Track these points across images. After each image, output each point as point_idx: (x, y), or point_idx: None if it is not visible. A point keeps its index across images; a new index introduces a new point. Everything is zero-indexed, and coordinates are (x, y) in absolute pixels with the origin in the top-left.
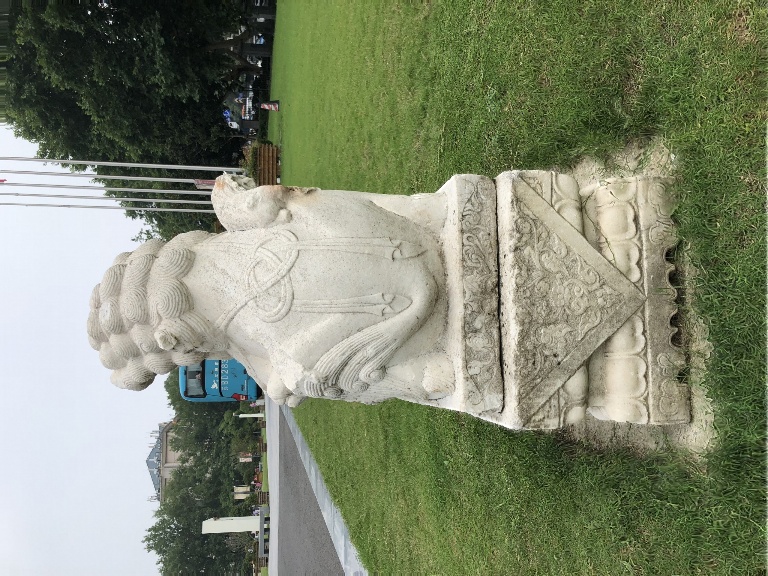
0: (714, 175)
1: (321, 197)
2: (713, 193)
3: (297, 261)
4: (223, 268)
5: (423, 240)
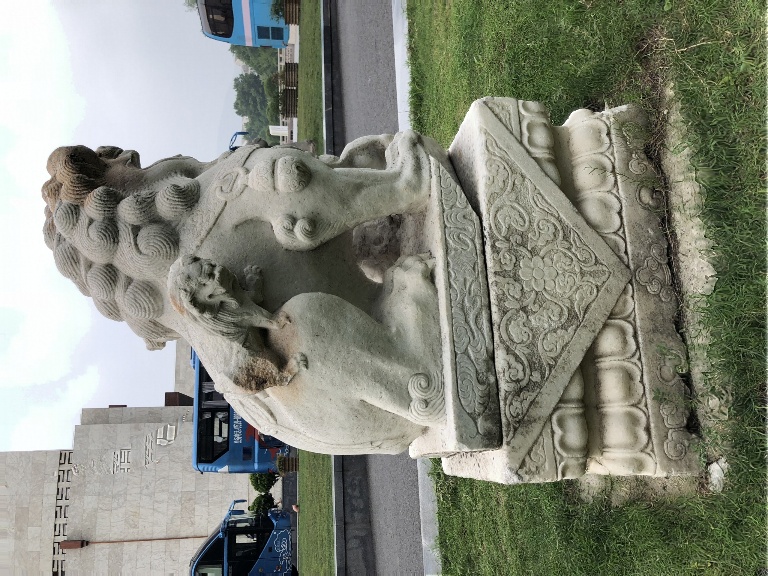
0: (678, 572)
1: (304, 395)
2: (665, 570)
3: (276, 435)
4: (200, 356)
5: (408, 430)
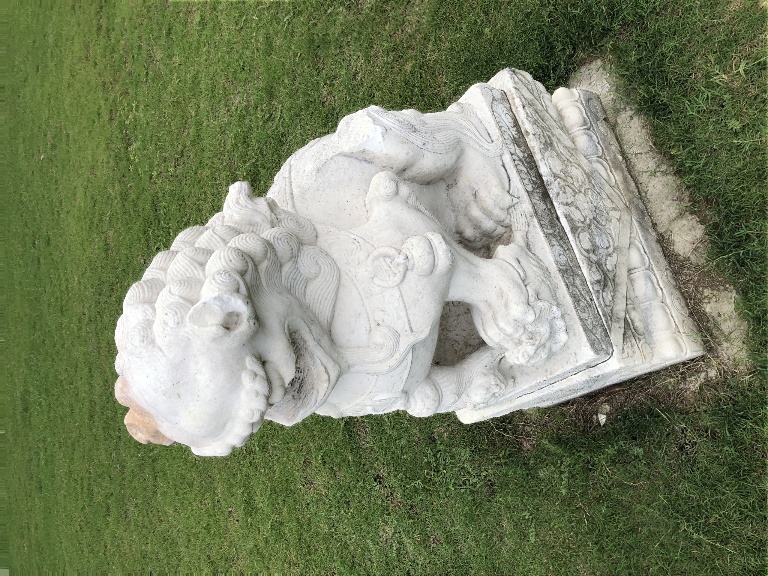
0: None
1: None
2: None
3: None
4: None
5: None
